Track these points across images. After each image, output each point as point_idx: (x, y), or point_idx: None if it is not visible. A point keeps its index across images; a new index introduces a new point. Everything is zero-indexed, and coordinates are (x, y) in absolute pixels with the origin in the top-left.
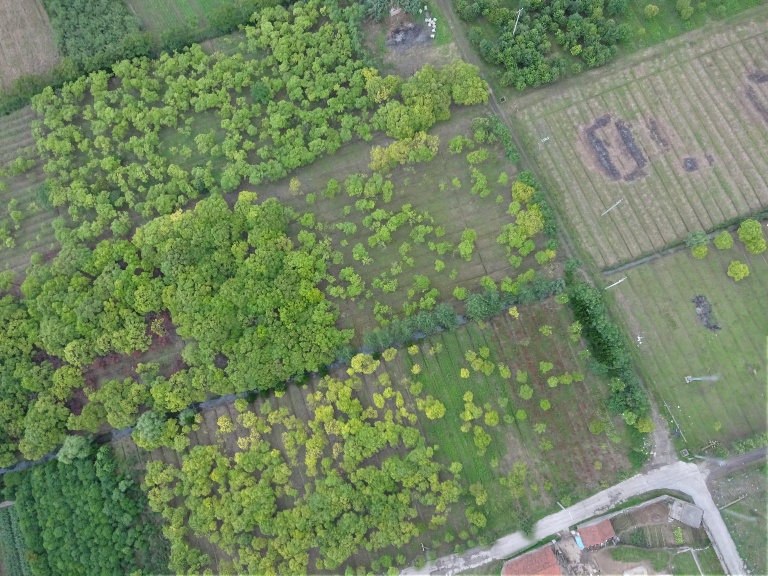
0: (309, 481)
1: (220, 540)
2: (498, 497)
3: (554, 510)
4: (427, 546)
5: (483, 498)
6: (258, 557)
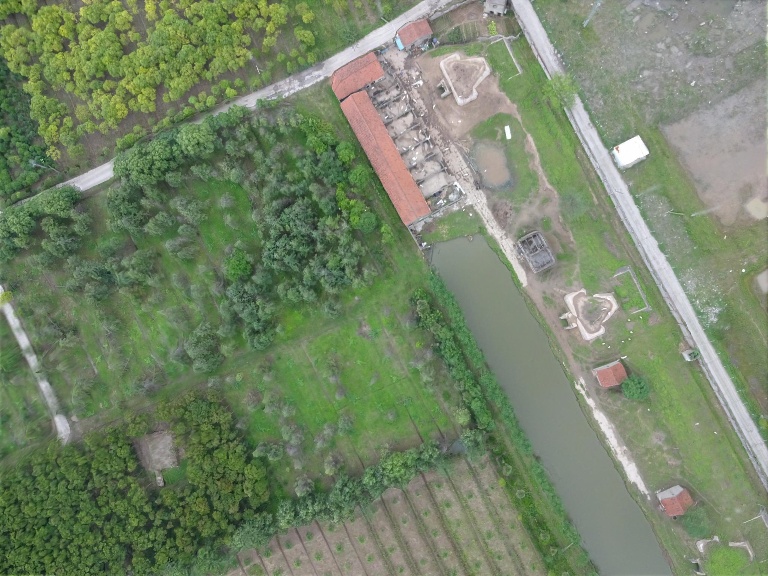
0: (150, 25)
1: (75, 88)
2: (327, 22)
3: (378, 25)
4: (261, 68)
5: (309, 15)
6: (109, 96)
